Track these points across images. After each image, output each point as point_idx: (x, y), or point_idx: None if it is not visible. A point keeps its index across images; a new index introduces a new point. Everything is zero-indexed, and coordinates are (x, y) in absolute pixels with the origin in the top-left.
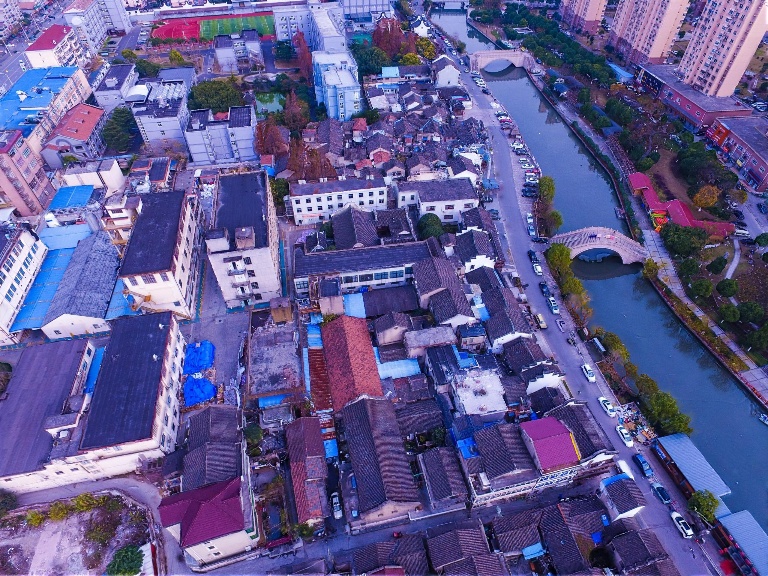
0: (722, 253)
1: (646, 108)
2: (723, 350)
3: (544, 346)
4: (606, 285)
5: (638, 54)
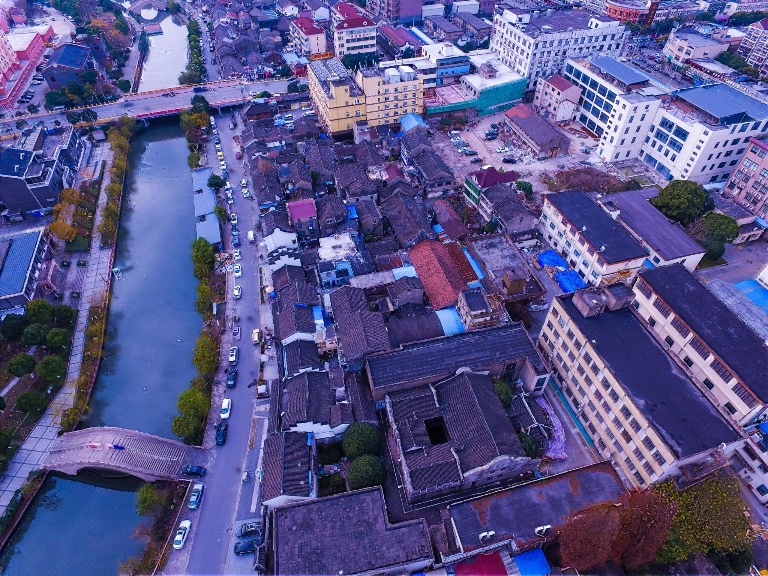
0: None
1: None
2: None
3: (264, 314)
4: None
5: None
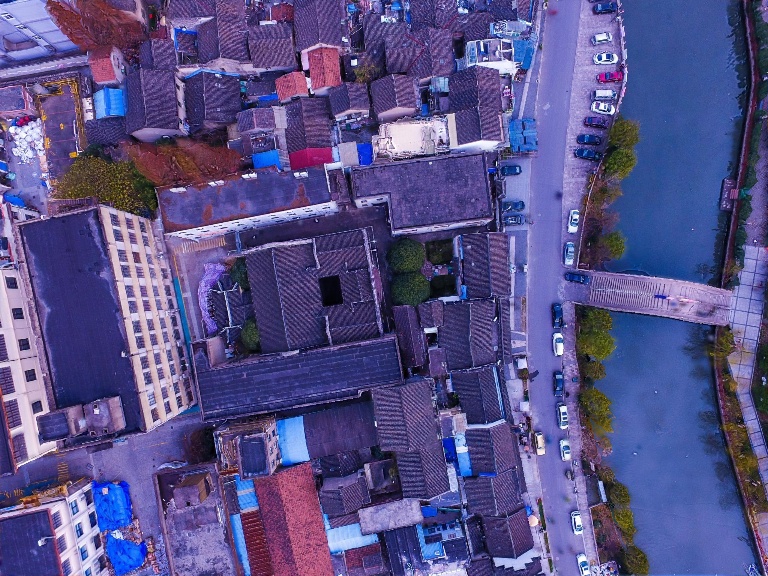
0: None
1: None
2: None
3: (534, 481)
4: (651, 326)
5: None
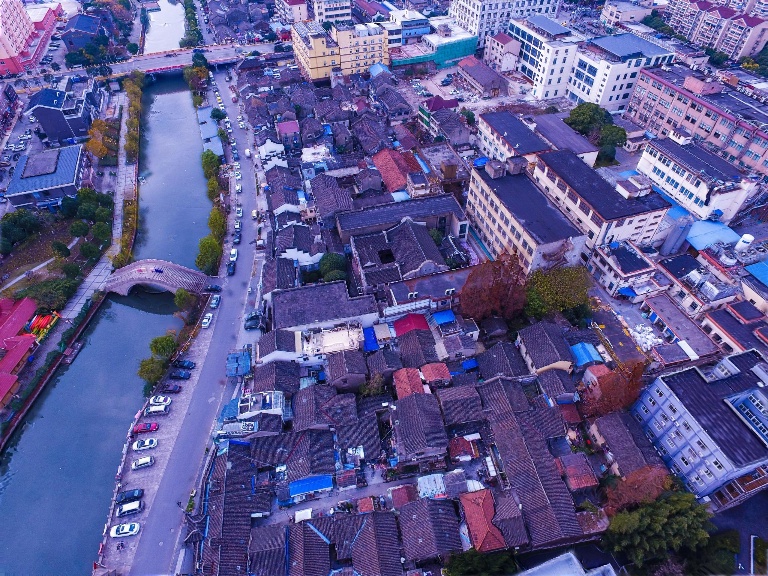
0: (21, 287)
1: None
2: None
3: (260, 201)
4: None
5: None
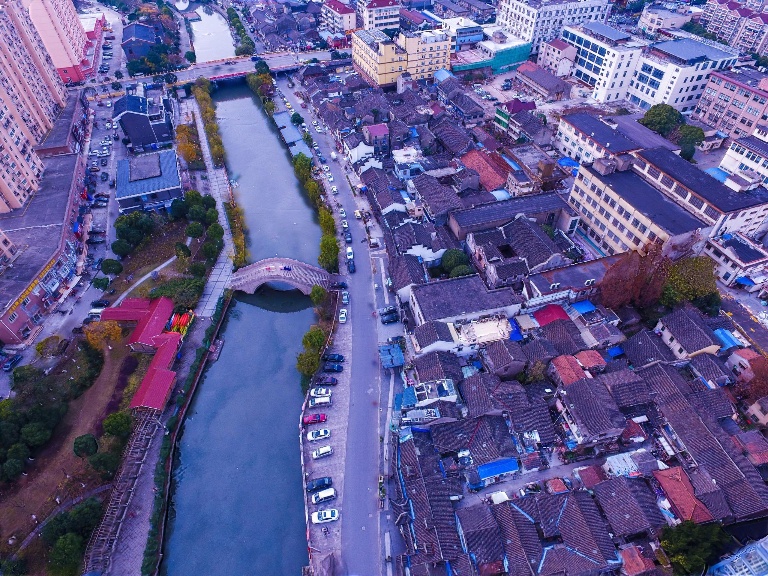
0: None
1: None
2: (231, 211)
3: (359, 202)
4: None
5: None
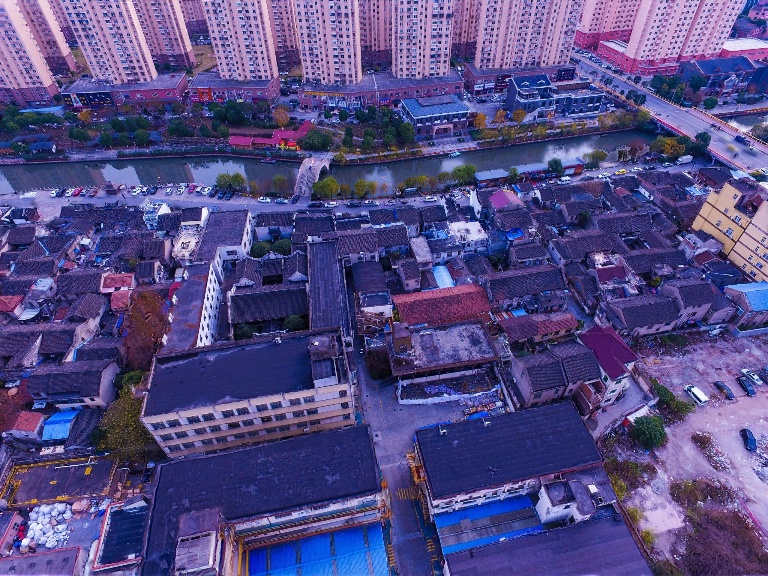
0: None
1: (125, 116)
2: (409, 154)
3: None
4: None
5: (28, 91)
